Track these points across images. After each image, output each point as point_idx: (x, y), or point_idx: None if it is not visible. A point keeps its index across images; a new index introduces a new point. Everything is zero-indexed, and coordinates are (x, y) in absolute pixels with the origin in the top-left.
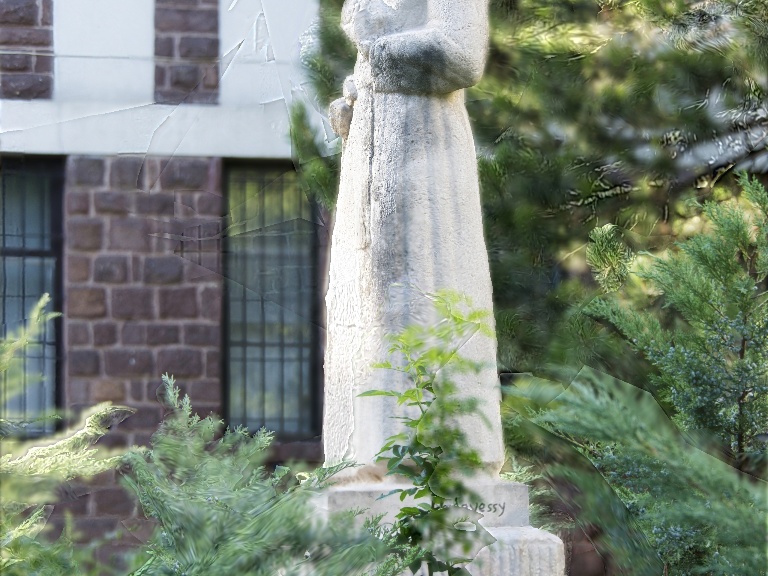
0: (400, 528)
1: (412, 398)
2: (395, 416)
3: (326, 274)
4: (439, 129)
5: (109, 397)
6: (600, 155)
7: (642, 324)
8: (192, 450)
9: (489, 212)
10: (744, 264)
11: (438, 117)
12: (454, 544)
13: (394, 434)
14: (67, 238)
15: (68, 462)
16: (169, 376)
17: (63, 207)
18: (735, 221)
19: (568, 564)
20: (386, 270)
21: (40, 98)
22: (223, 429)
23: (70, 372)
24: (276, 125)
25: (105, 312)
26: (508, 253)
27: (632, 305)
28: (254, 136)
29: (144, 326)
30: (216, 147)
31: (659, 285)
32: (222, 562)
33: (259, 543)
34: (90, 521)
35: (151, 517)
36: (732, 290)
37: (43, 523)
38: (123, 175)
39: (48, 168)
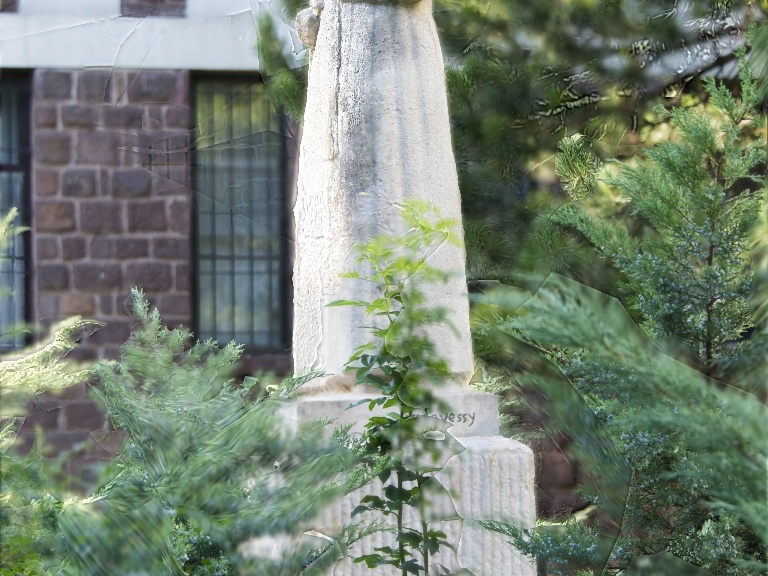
0: (369, 438)
1: (380, 308)
2: (363, 326)
3: (295, 186)
4: (406, 39)
5: (78, 311)
6: (568, 65)
7: (609, 232)
8: (160, 362)
9: (457, 123)
10: (711, 171)
11: (405, 27)
12: (423, 453)
13: (362, 344)
14: (35, 152)
15: (37, 376)
16: (138, 290)
17: (30, 121)
18: (702, 127)
19: (538, 474)
20: (354, 181)
21: (6, 11)
22: (193, 342)
23: (39, 286)
24: (243, 37)
25: (73, 226)
26: (477, 164)
27: (599, 213)
28: (221, 48)
29: (113, 240)
30: (183, 60)
31: (626, 192)
32: (190, 473)
33: (227, 454)
34: (61, 435)
35: (119, 429)
36: (699, 197)
37: (13, 437)
38: (90, 88)
39: (15, 82)
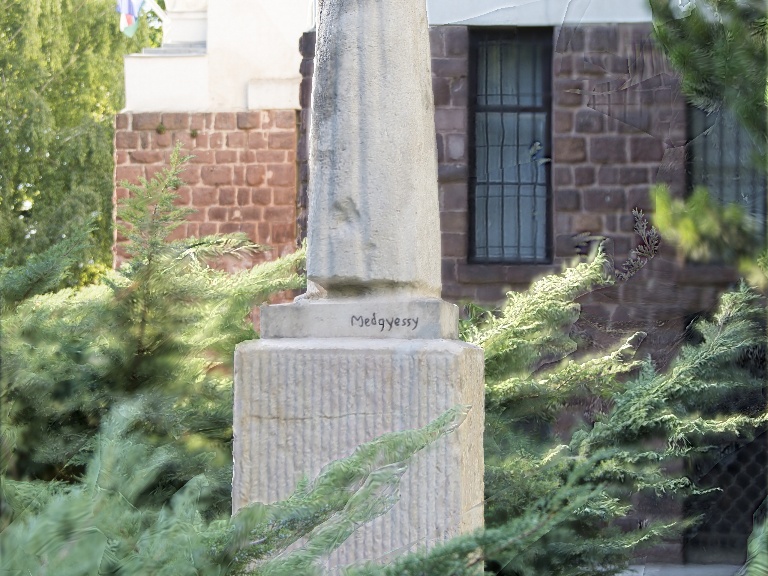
0: None
1: None
2: None
3: None
4: None
5: (588, 229)
6: None
7: None
8: None
9: None
10: None
11: None
12: None
13: None
14: (554, 96)
15: (246, 281)
16: (638, 211)
17: (551, 70)
18: None
19: (767, 374)
20: (319, 111)
21: None
22: None
23: (556, 208)
24: None
25: (585, 158)
26: None
27: None
28: (638, 3)
29: (617, 169)
30: (612, 14)
31: None
32: None
33: None
34: None
35: None
36: None
37: None
38: None
39: (538, 38)
